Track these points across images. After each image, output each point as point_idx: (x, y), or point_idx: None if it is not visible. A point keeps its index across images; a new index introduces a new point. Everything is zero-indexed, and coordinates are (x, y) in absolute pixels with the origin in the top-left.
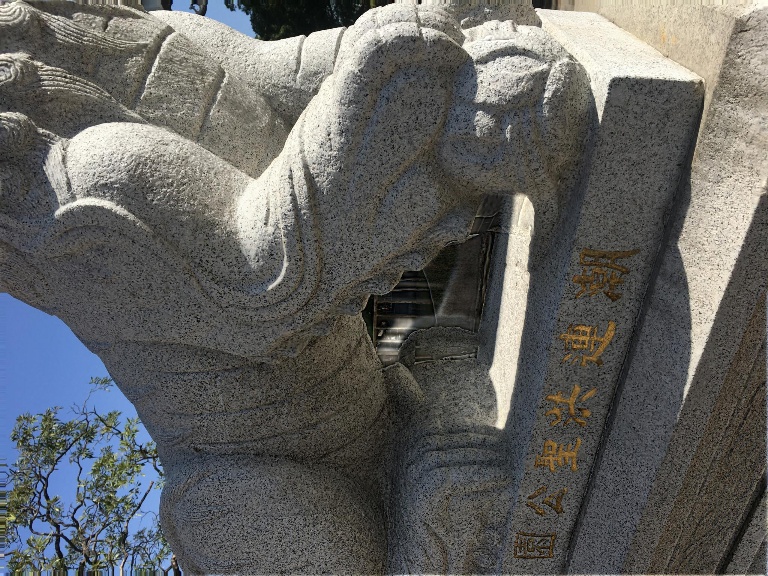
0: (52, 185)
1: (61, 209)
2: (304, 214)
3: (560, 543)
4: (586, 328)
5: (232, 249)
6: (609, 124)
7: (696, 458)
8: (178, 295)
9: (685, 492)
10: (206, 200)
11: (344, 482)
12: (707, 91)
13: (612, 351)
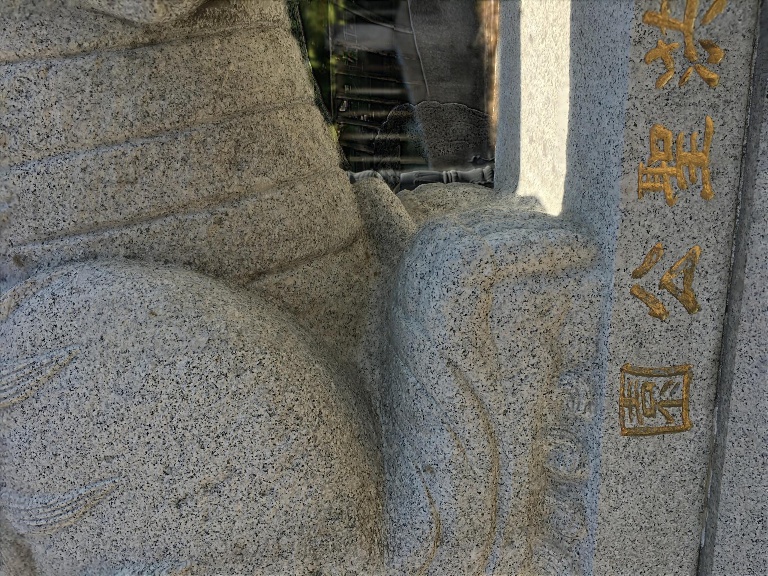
0: None
1: None
2: None
3: (700, 390)
4: None
5: None
6: None
7: None
8: None
9: None
10: None
11: (295, 328)
12: None
13: None
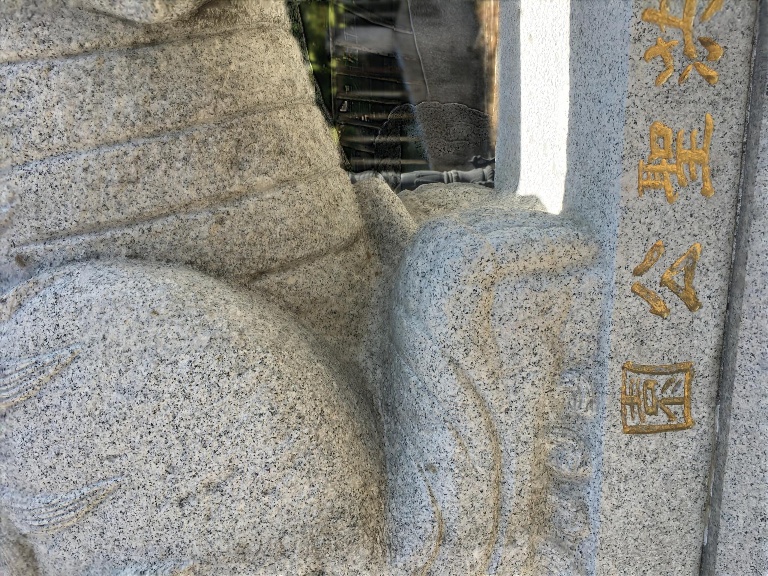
0: None
1: None
2: None
3: (702, 388)
4: None
5: None
6: None
7: None
8: None
9: None
10: None
11: (297, 328)
12: None
13: None
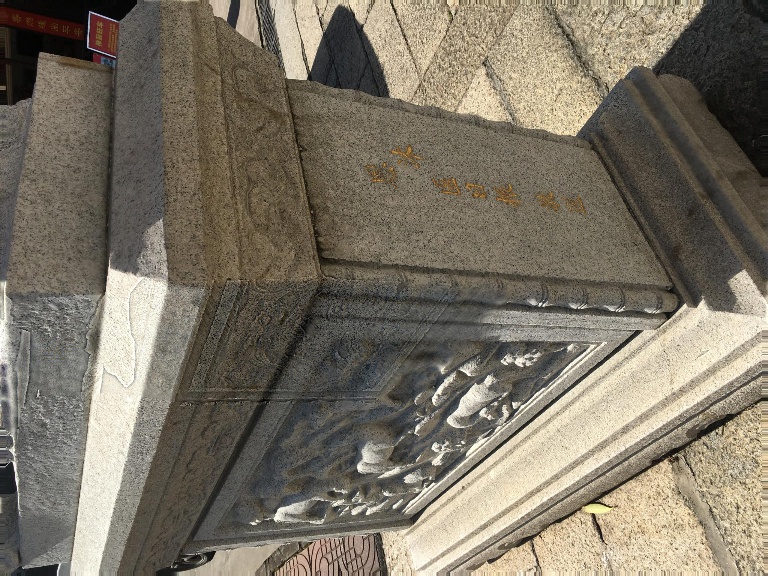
0: None
1: None
2: None
3: None
4: None
5: None
6: None
7: None
8: None
9: None
10: None
11: None
12: None
13: None
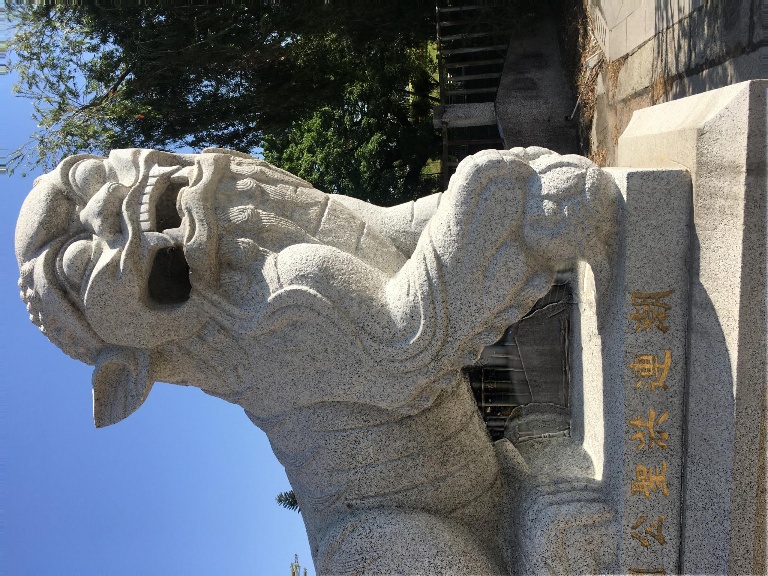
0: (267, 281)
1: (273, 295)
2: (435, 282)
3: None
4: (648, 357)
5: (385, 315)
6: (632, 202)
7: (762, 459)
8: (346, 355)
9: (763, 497)
10: (366, 284)
11: (471, 536)
12: (692, 175)
13: (673, 376)
